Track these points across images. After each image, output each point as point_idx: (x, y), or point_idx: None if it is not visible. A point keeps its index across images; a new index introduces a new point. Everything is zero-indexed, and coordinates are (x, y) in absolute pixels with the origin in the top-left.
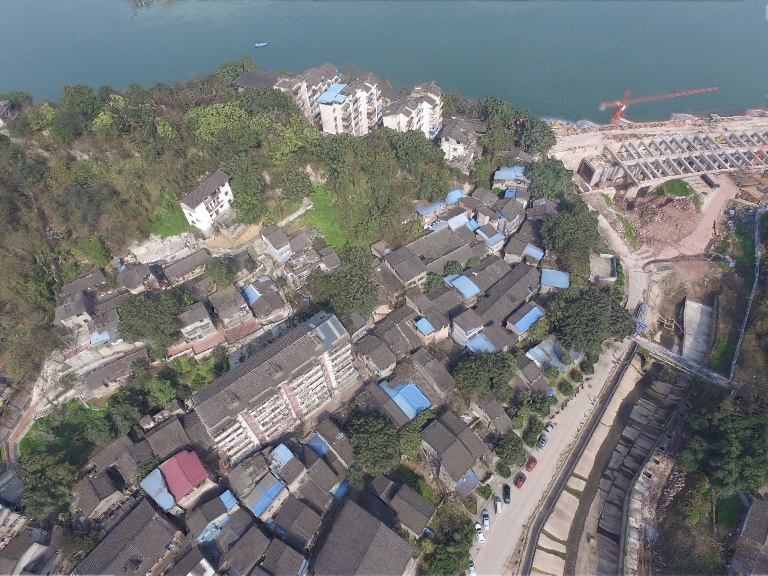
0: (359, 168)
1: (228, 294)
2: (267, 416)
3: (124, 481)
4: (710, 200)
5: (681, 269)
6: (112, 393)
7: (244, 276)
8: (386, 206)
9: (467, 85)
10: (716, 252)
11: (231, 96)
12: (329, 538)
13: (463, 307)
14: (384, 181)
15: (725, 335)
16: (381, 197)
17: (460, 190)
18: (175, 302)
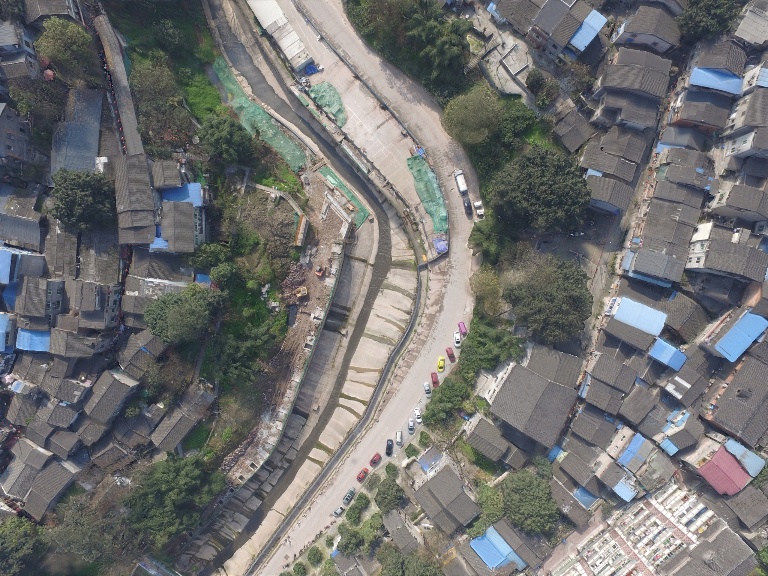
0: None
1: None
2: (657, 536)
3: None
4: None
5: None
6: None
7: None
8: None
9: None
10: None
11: None
12: None
13: None
14: None
15: None
16: None
17: None
18: None
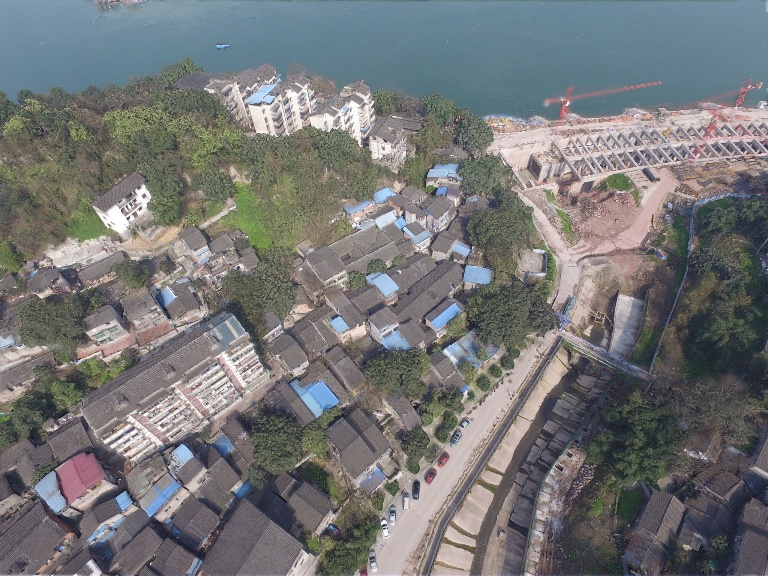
0: (280, 168)
1: (139, 296)
2: (164, 417)
3: (24, 484)
4: (650, 194)
5: (615, 263)
6: (19, 397)
7: (161, 278)
8: (311, 206)
9: (424, 83)
10: (652, 246)
11: (159, 98)
12: (220, 537)
13: (384, 305)
14: (308, 181)
15: (651, 328)
16: (305, 197)
17: (391, 188)
18: (78, 305)
